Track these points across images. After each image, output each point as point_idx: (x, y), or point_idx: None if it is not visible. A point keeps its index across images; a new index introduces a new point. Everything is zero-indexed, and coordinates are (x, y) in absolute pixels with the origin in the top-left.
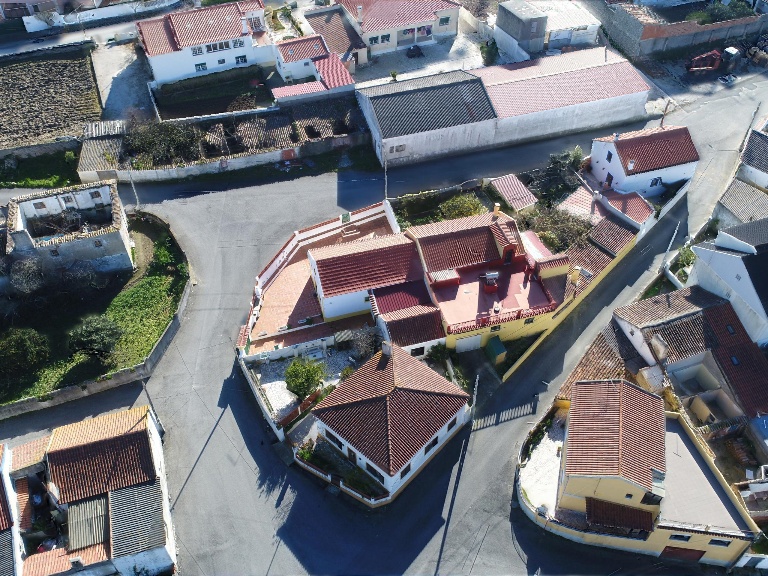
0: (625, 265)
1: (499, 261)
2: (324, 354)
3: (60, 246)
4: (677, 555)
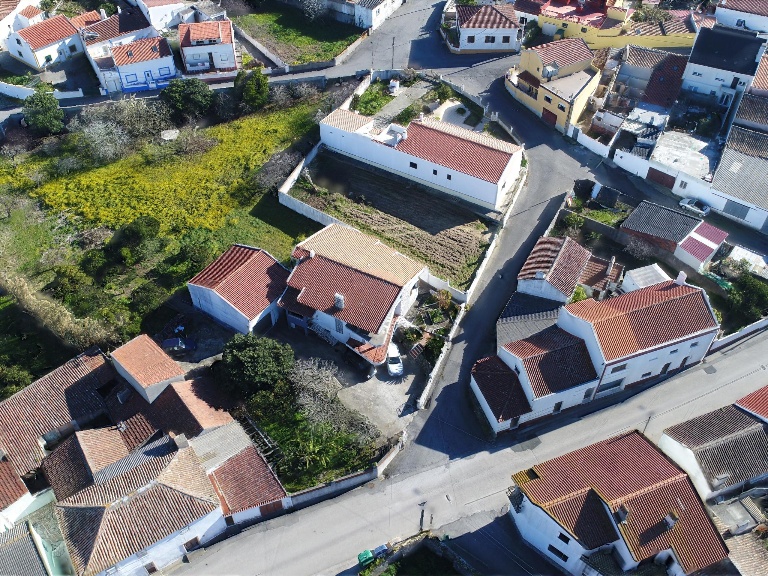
0: (674, 49)
1: (597, 4)
2: None
3: None
4: (548, 119)
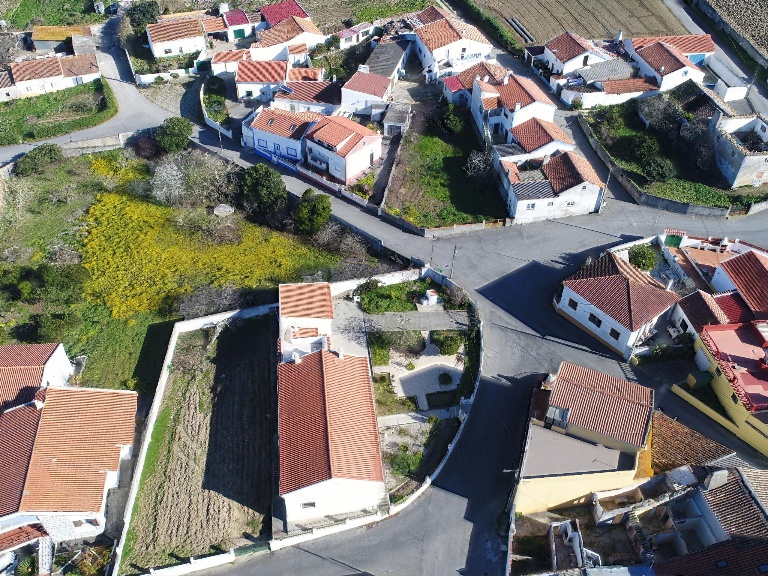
0: None
1: None
2: (675, 280)
3: (723, 137)
4: None
